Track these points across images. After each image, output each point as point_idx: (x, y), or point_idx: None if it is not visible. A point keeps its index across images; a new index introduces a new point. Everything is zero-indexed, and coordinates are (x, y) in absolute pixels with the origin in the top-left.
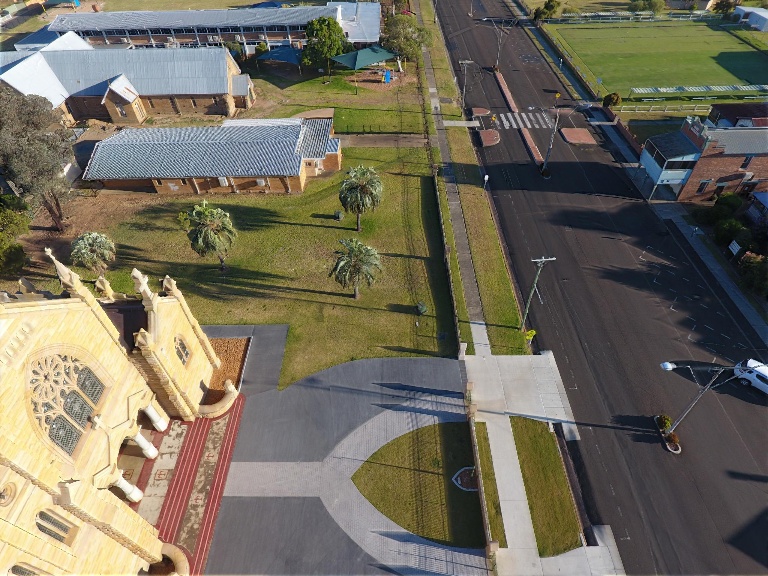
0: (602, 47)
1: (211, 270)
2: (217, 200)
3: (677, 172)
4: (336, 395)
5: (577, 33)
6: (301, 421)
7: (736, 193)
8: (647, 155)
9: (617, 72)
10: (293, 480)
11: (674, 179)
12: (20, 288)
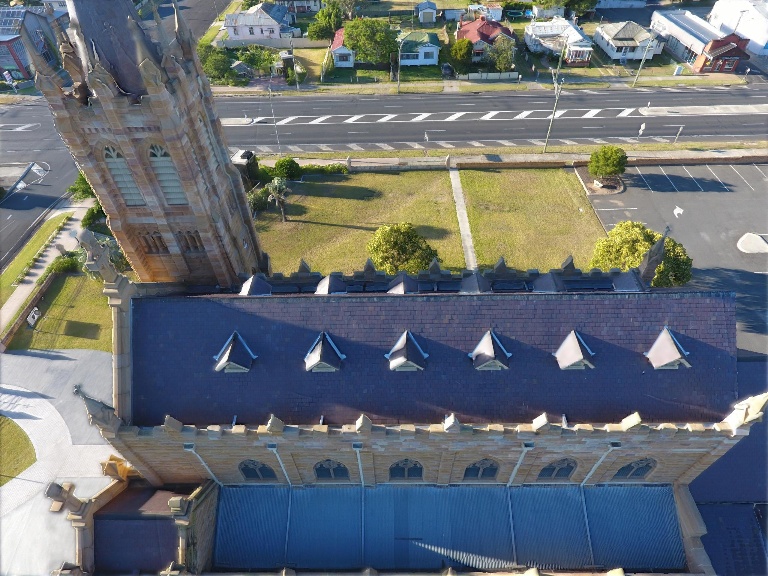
0: None
1: None
2: None
3: None
4: (4, 563)
5: None
6: (60, 525)
7: None
8: None
9: None
10: (91, 459)
11: None
12: (176, 420)
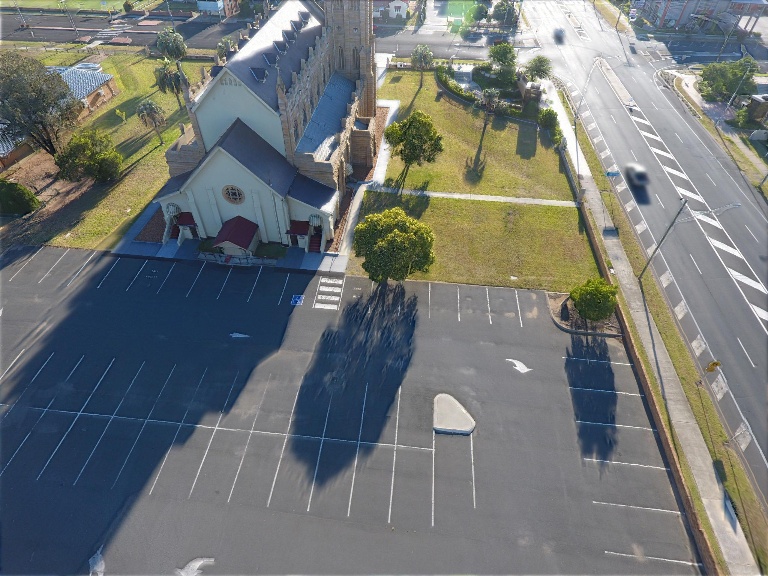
0: (44, 0)
1: (179, 112)
2: (94, 117)
3: (220, 1)
4: None
5: (6, 1)
6: None
7: (235, 6)
8: (201, 3)
9: (87, 4)
10: None
11: (221, 6)
12: None
